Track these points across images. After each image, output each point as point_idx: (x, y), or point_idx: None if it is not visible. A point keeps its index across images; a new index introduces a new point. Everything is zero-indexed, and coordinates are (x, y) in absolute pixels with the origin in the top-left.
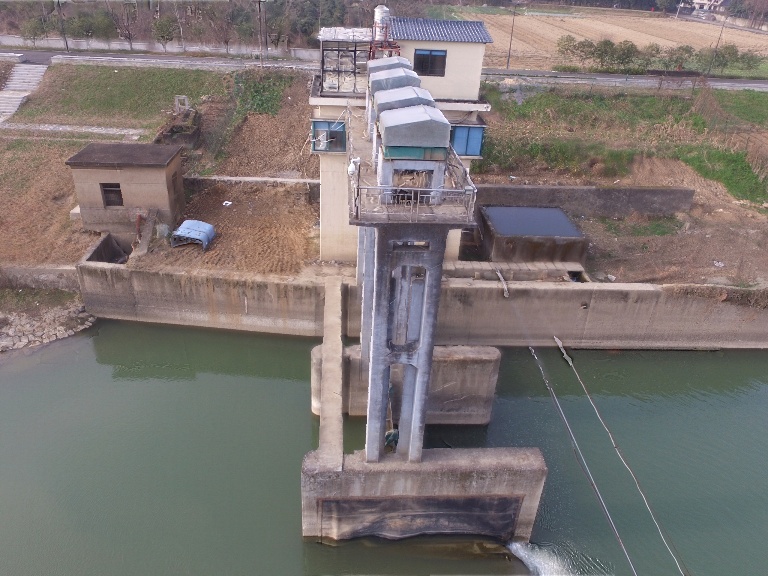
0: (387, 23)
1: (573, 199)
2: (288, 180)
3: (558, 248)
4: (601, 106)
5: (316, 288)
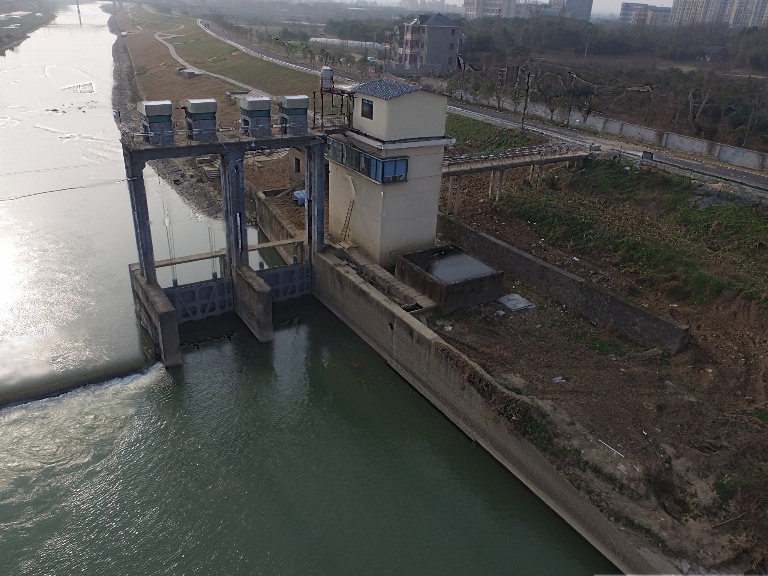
0: (324, 77)
1: (559, 283)
2: None
3: None
4: None
5: None
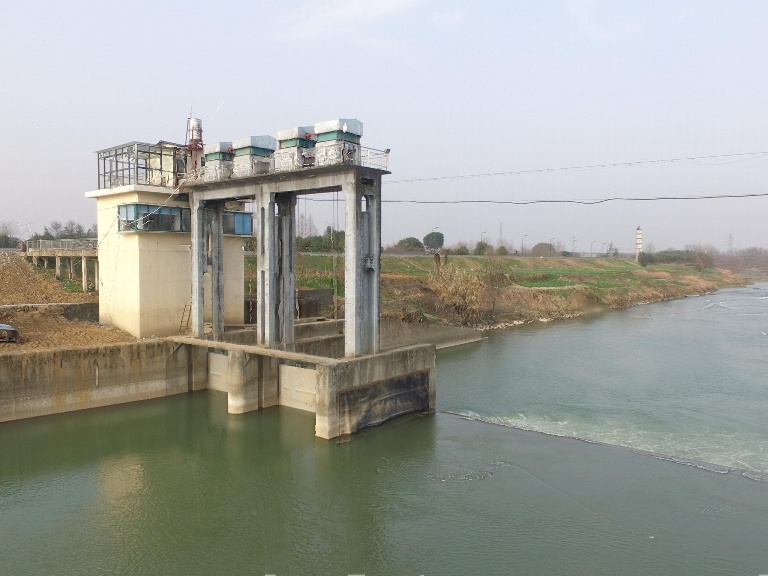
0: None
1: None
2: (39, 304)
3: (303, 307)
4: None
5: (167, 343)
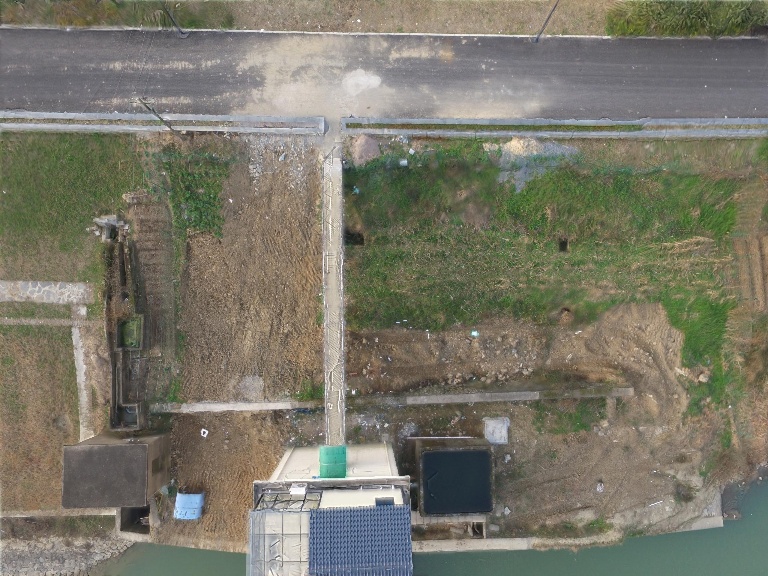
0: None
1: None
2: (252, 409)
3: None
4: (620, 193)
5: None
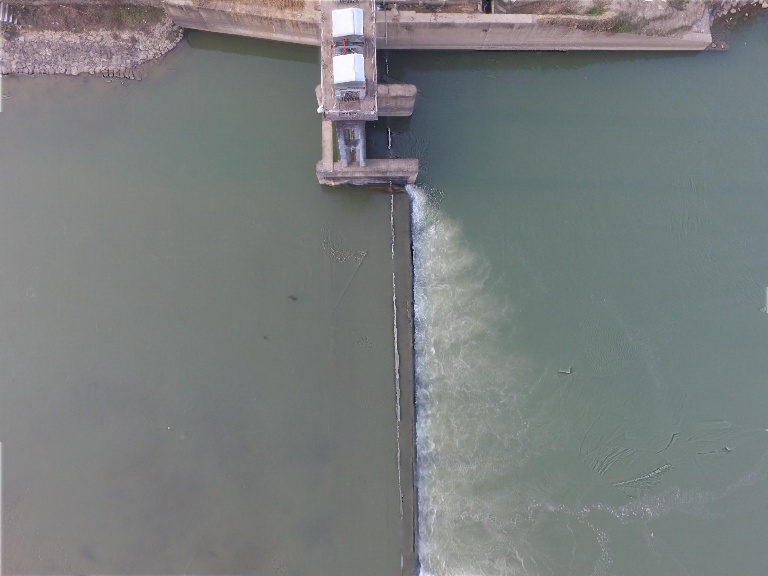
0: None
1: None
2: None
3: None
4: None
5: (315, 24)
